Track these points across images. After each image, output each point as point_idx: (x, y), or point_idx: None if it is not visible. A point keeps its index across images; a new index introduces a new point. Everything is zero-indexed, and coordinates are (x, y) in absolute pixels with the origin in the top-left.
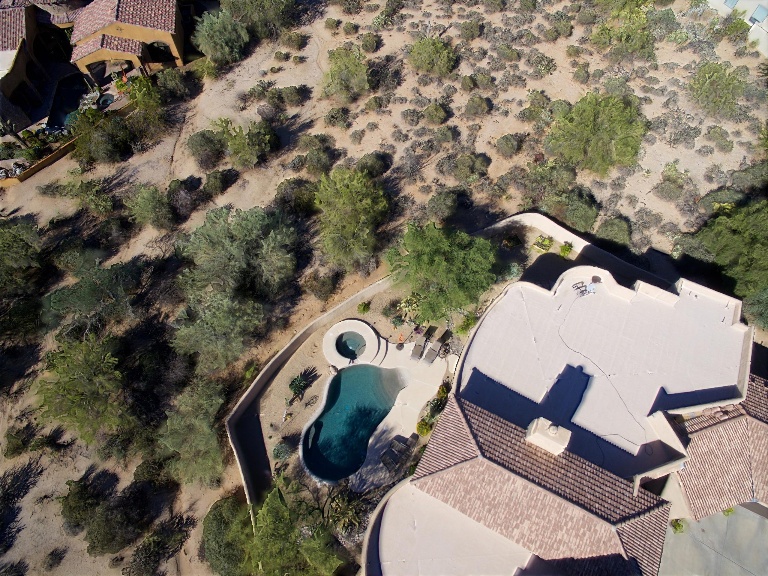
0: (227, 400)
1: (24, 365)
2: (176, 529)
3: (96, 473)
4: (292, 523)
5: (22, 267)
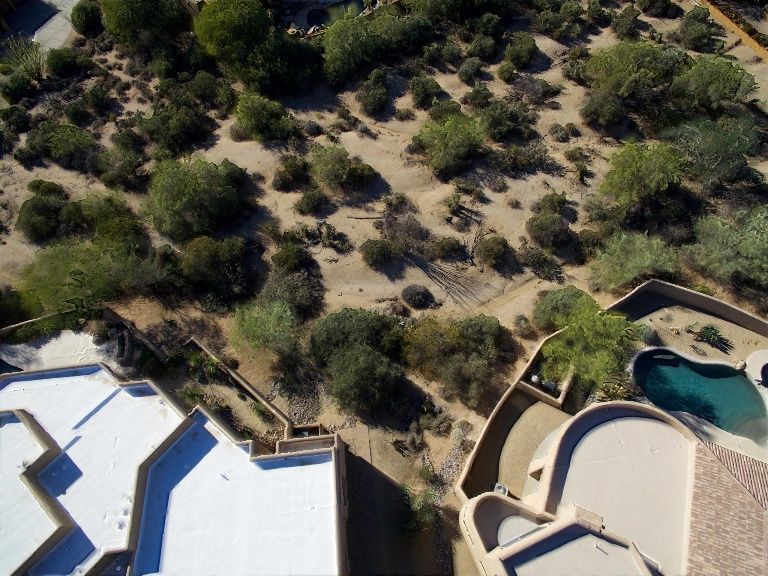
0: (664, 279)
1: (626, 137)
2: (553, 271)
3: (574, 207)
4: (589, 353)
5: (712, 97)
